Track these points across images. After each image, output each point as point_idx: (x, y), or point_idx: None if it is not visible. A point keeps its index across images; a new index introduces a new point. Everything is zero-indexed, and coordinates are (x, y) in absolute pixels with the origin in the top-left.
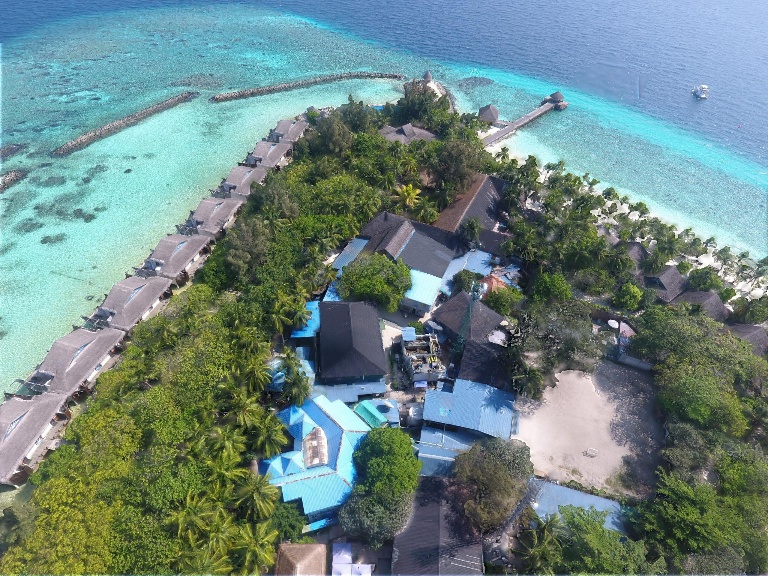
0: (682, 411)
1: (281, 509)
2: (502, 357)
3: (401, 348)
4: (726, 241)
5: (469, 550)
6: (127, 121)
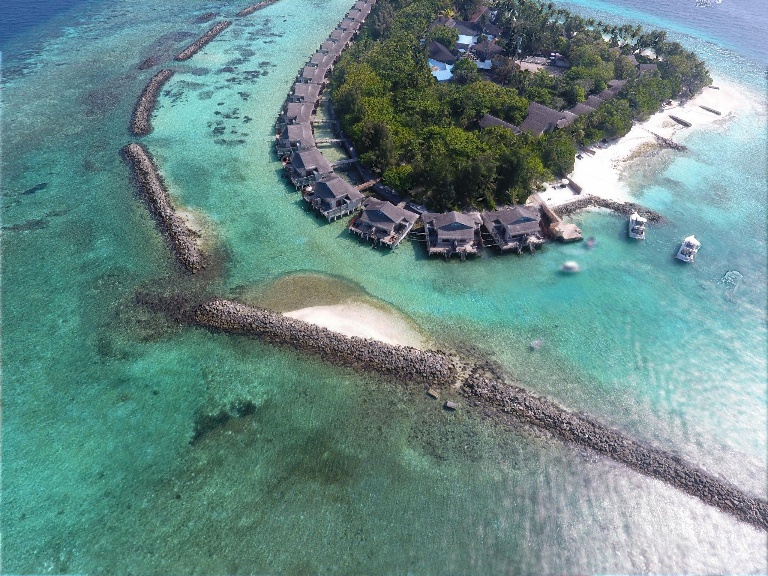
0: None
1: None
2: (504, 52)
3: (458, 59)
4: None
5: (498, 84)
6: (267, 3)
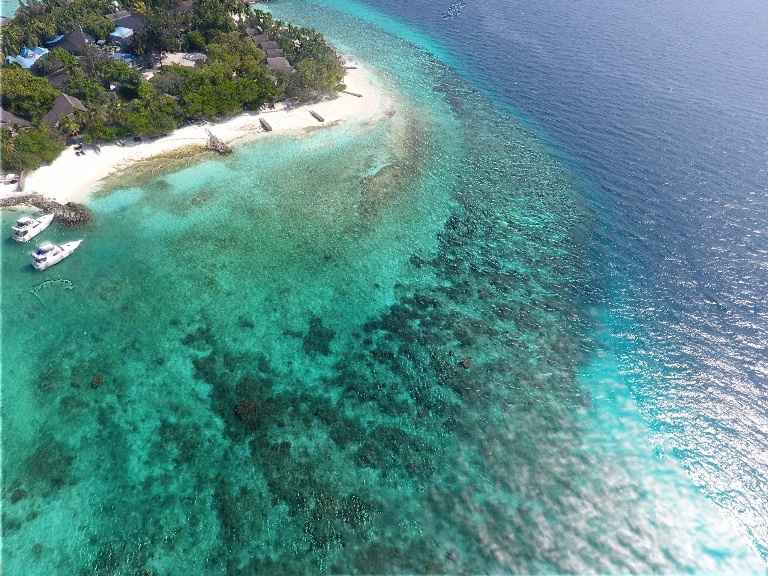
0: None
1: (8, 66)
2: None
3: None
4: None
5: None
6: None
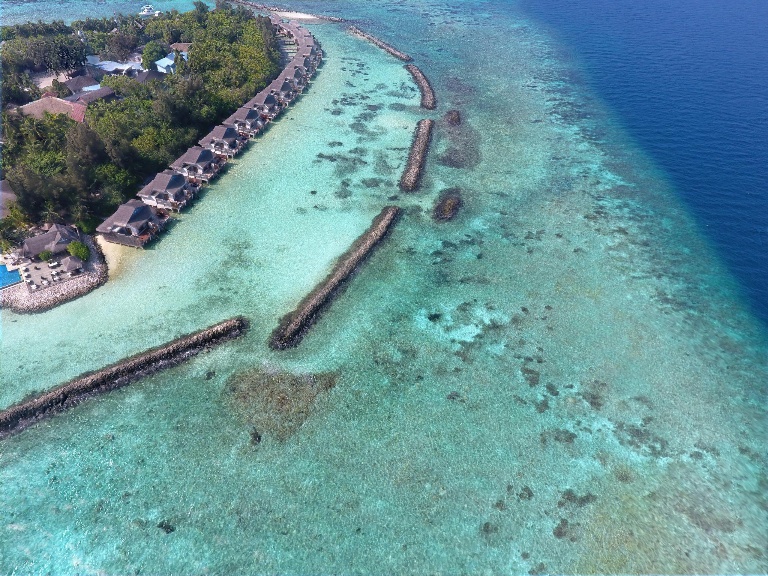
0: None
1: None
2: None
3: None
4: None
5: None
6: None
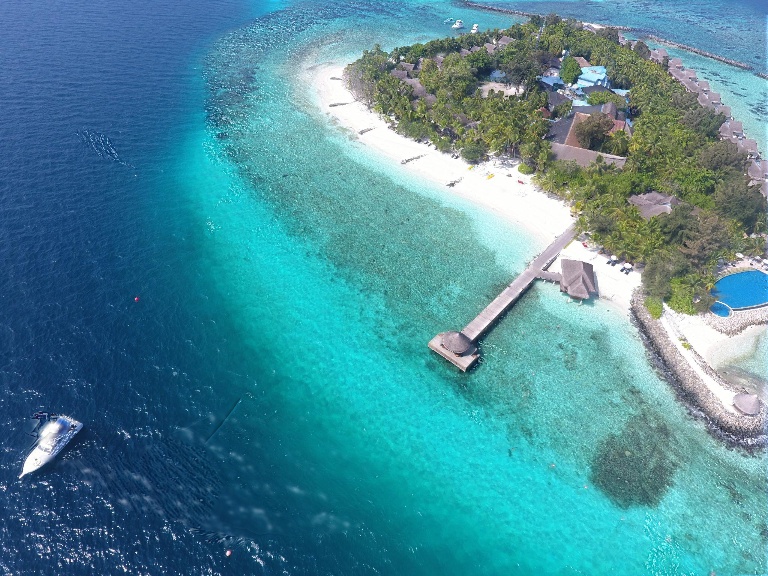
0: None
1: None
2: None
3: None
4: (356, 151)
5: None
6: None
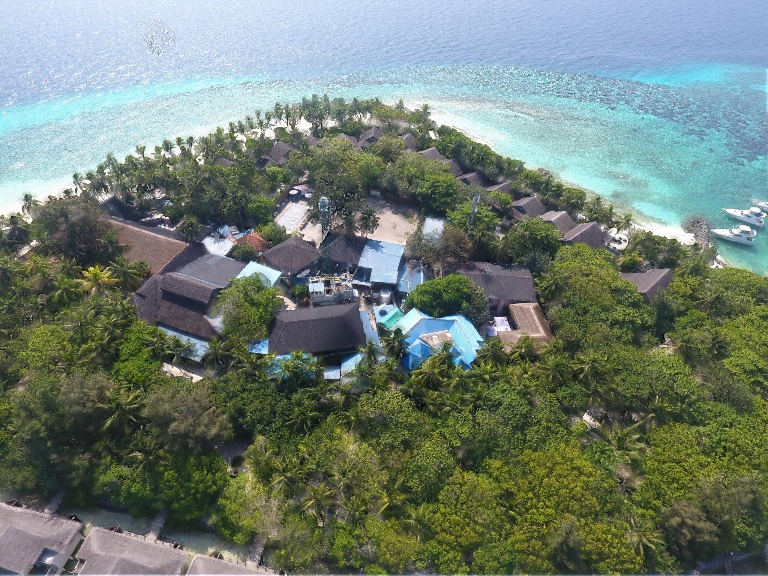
0: (372, 178)
1: None
2: None
3: (320, 302)
4: (204, 131)
5: (479, 266)
6: None
